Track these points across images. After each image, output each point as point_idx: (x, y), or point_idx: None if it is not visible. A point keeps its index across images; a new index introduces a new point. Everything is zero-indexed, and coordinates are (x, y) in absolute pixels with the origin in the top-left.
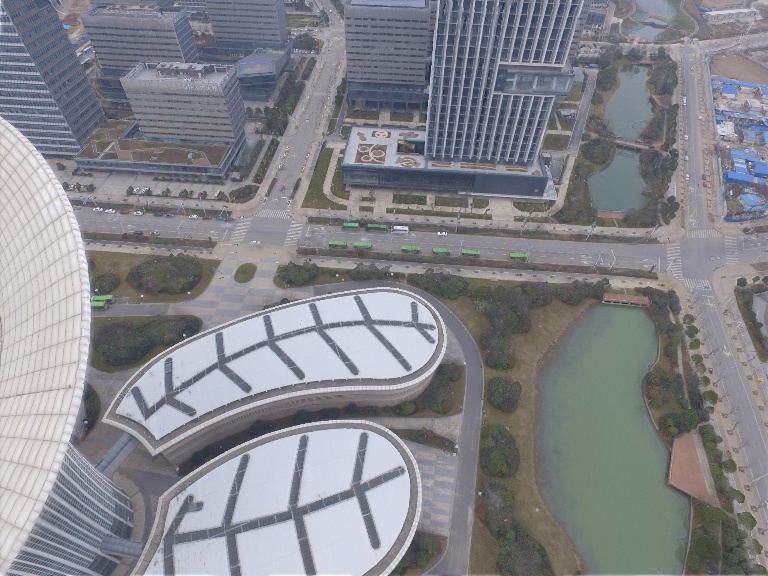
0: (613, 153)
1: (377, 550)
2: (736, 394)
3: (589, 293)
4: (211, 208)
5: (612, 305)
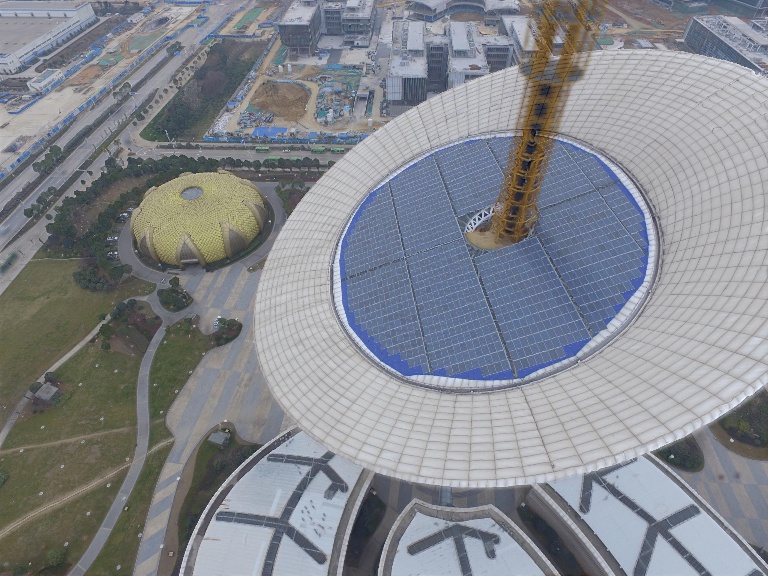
0: None
1: None
2: None
3: None
4: None
5: None
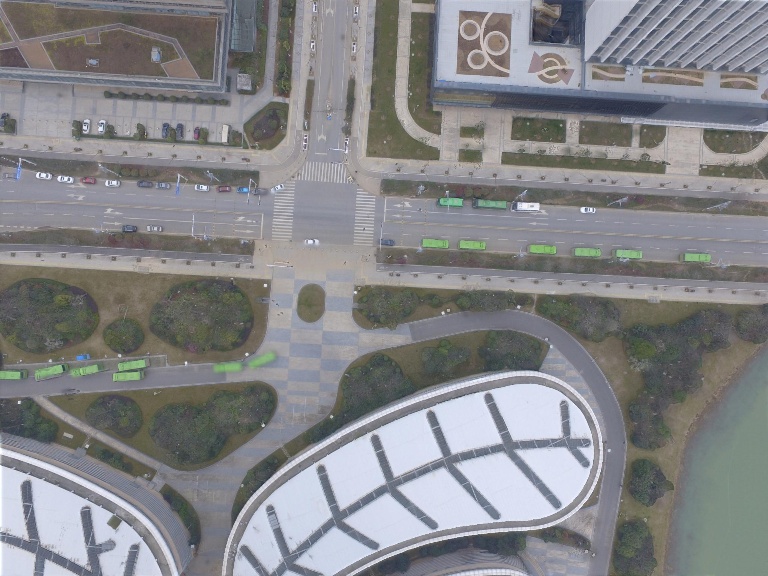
0: None
1: None
2: None
3: None
4: (223, 164)
5: None
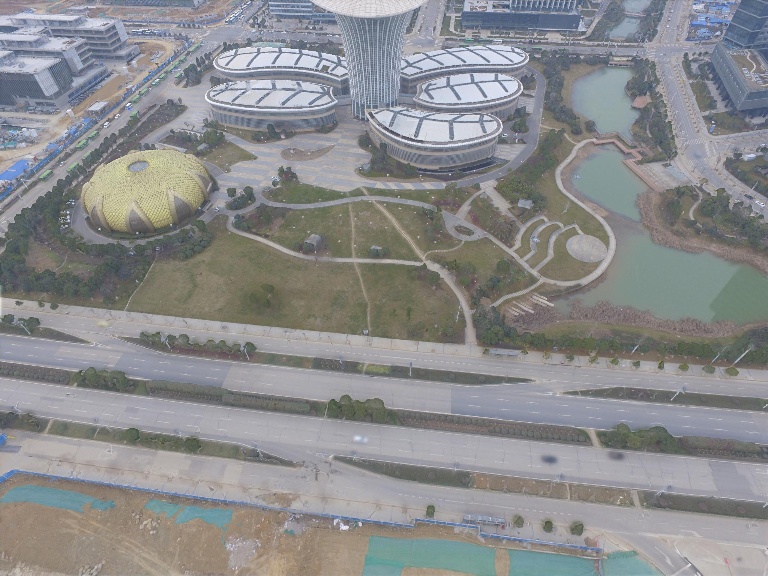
0: (623, 18)
1: (507, 92)
2: (672, 87)
3: (601, 60)
4: None
5: (614, 67)
